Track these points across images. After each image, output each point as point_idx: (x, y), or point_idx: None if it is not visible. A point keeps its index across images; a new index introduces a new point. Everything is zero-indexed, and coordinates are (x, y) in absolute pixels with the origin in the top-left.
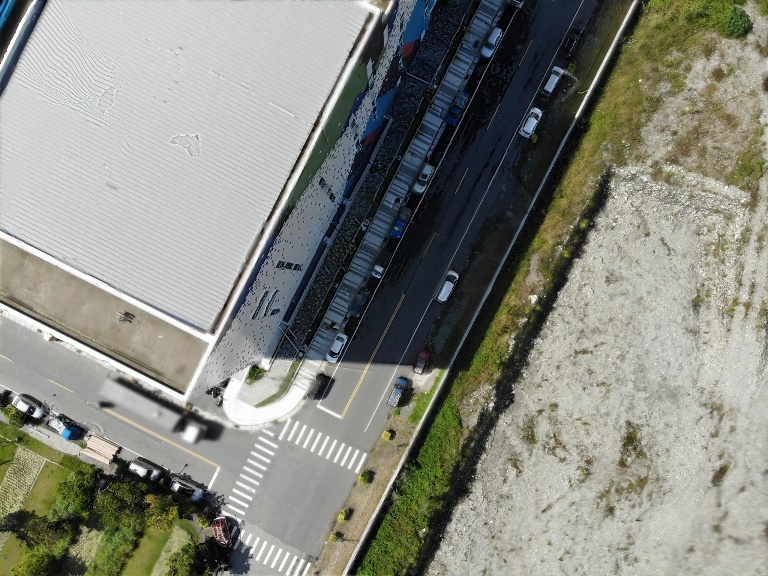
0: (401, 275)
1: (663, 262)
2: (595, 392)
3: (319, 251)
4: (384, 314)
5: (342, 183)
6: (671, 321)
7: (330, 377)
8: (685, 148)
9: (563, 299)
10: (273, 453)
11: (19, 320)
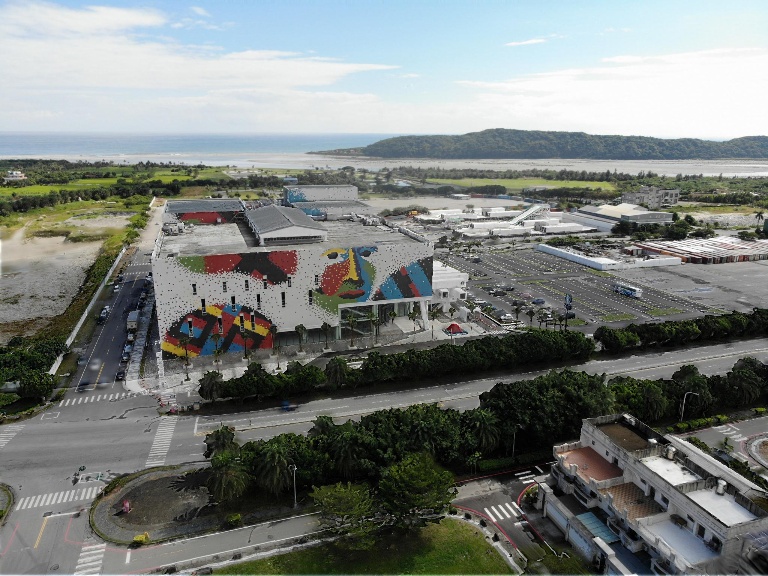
0: None
1: None
2: (38, 304)
3: None
4: None
5: None
6: None
7: None
8: None
9: None
10: None
11: None
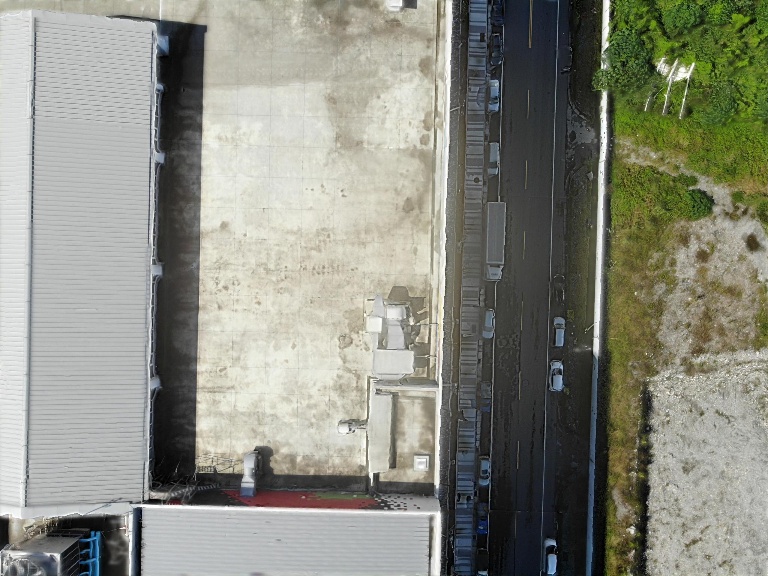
0: (503, 563)
1: (727, 432)
2: (720, 573)
3: None
4: None
5: None
6: (759, 480)
7: None
8: (704, 335)
9: (653, 505)
10: None
11: None
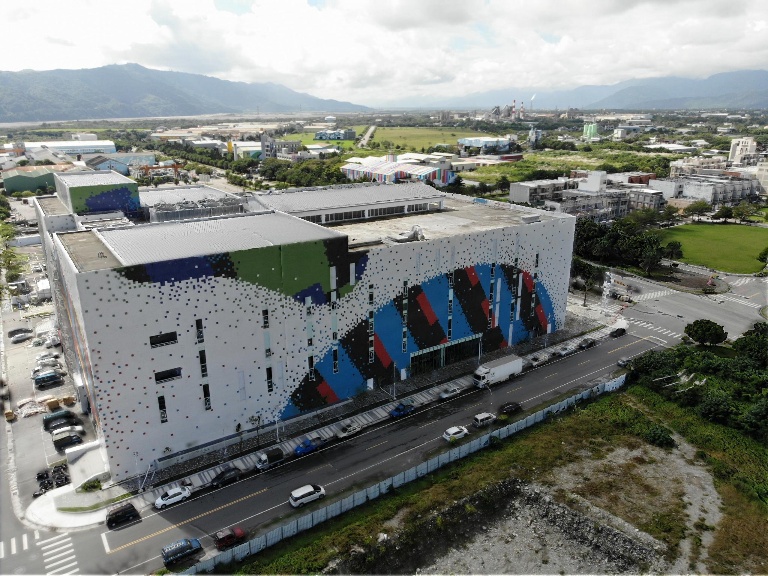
0: (278, 477)
1: None
2: None
3: (232, 436)
4: (237, 495)
5: (285, 386)
6: None
7: (141, 518)
8: (595, 490)
9: None
10: (15, 552)
11: (8, 405)
